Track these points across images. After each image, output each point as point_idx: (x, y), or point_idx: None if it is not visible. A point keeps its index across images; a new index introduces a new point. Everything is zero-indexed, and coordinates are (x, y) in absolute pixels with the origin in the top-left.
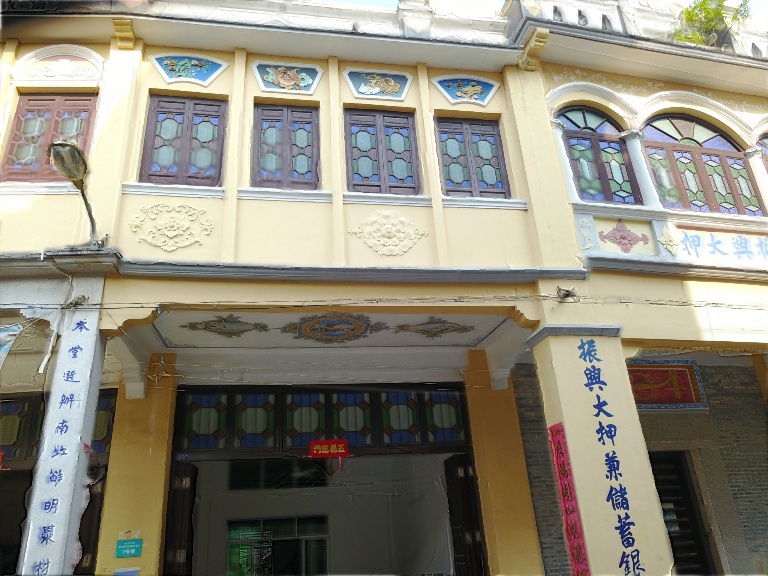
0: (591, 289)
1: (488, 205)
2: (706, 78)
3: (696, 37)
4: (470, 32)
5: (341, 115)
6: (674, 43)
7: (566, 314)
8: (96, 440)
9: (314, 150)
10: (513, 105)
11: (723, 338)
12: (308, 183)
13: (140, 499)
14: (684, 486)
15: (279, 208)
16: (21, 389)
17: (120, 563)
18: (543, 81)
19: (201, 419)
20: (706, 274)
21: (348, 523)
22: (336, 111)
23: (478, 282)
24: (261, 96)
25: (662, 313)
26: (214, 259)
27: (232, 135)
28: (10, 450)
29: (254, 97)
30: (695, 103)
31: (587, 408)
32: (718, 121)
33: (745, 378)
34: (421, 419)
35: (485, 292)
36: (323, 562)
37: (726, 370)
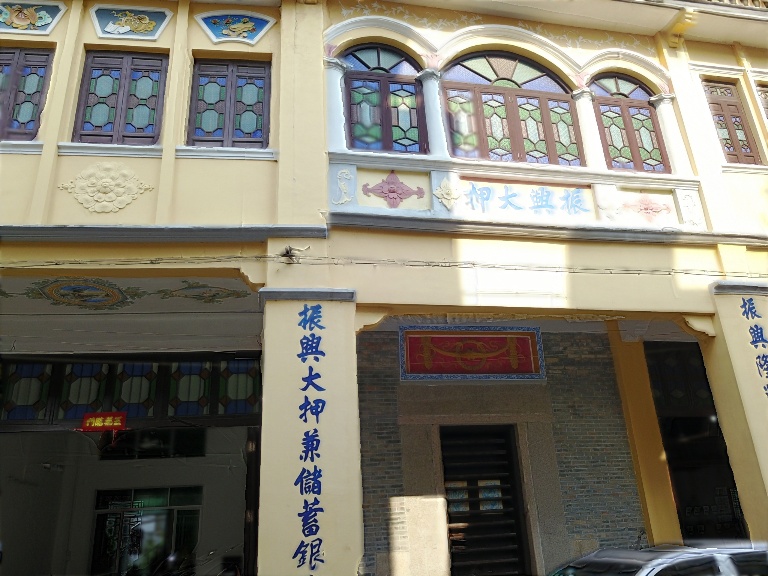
0: (333, 248)
1: (229, 155)
2: (531, 9)
3: None
4: None
5: (81, 57)
6: None
7: (293, 276)
8: None
9: (42, 97)
10: (281, 43)
11: (490, 303)
12: (28, 133)
13: None
14: (510, 462)
15: None
16: None
17: None
18: (324, 15)
19: None
20: (480, 231)
21: (223, 493)
22: (69, 53)
23: (193, 241)
24: None
25: (417, 275)
26: None
27: None
28: None
29: None
30: (516, 38)
31: (294, 381)
32: (543, 59)
33: (596, 346)
34: (213, 390)
35: (202, 252)
36: (195, 532)
37: (574, 337)
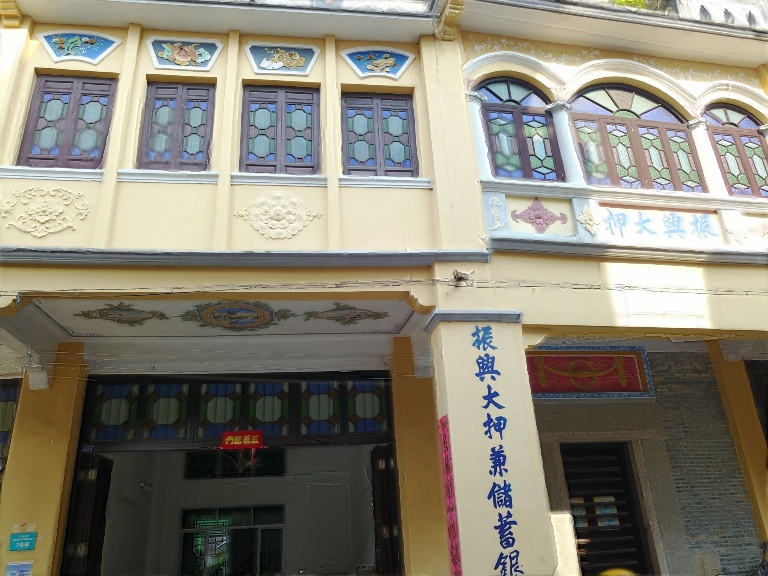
0: (494, 272)
1: (388, 184)
2: (647, 44)
3: (637, 0)
4: (387, 1)
5: (240, 92)
6: (605, 7)
7: (462, 299)
8: (3, 431)
9: (207, 129)
10: (425, 77)
11: (641, 323)
12: (198, 164)
13: (38, 491)
14: (625, 479)
15: (162, 190)
16: None
17: (13, 556)
18: (461, 51)
19: (111, 409)
20: (626, 255)
21: (305, 512)
22: (232, 88)
23: (367, 266)
24: (155, 74)
25: (573, 297)
26: (85, 245)
27: (117, 115)
28: None
29: (146, 75)
30: (634, 72)
31: (475, 399)
32: (659, 91)
33: (699, 365)
34: (342, 409)
35: (375, 276)
36: (279, 551)
37: (678, 357)
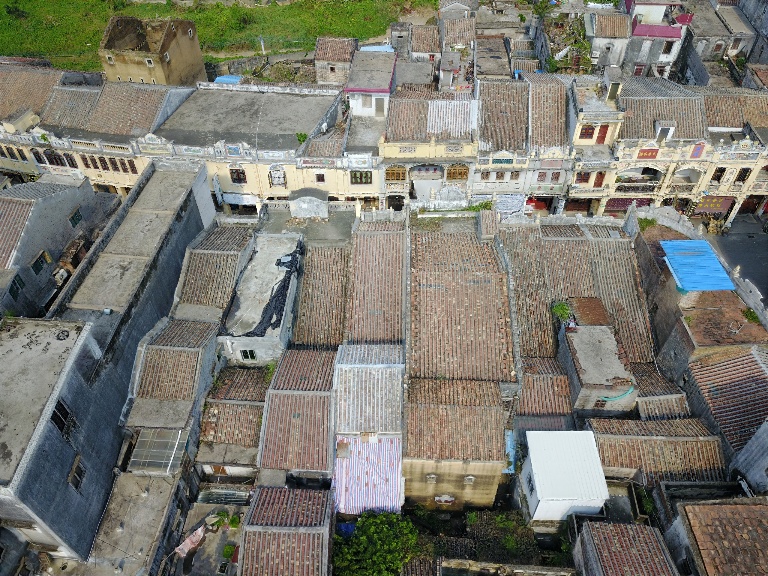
0: None
1: None
2: None
3: None
4: None
5: (5, 147)
6: None
7: None
8: None
9: None
10: None
11: None
12: None
13: None
14: None
15: None
16: None
17: None
18: None
19: None
20: None
21: None
22: None
23: None
24: None
25: None
26: None
27: None
28: None
29: None
30: None
31: None
32: None
33: None
34: None
35: None
36: None
37: None
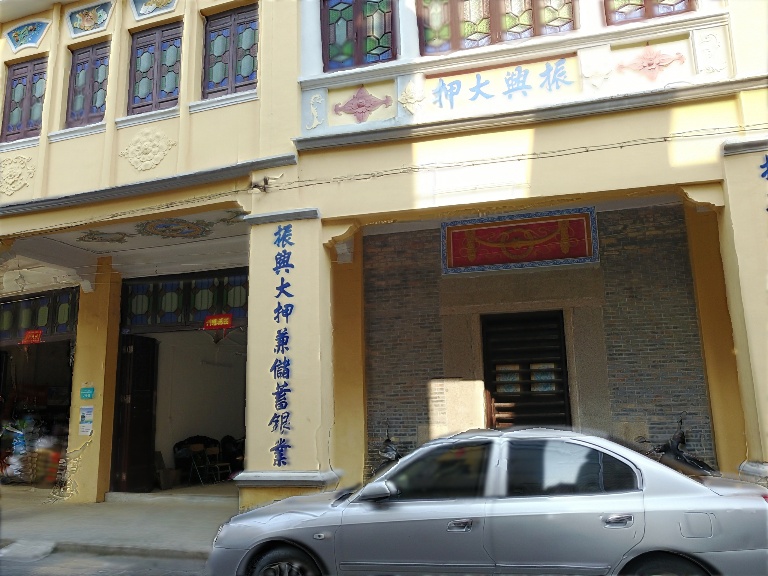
0: (304, 172)
1: (226, 103)
2: None
3: None
4: None
5: (129, 42)
6: None
7: (270, 202)
8: None
9: None
10: None
11: (447, 202)
12: (102, 115)
13: (93, 362)
14: (560, 346)
15: (76, 144)
16: (44, 289)
17: (83, 403)
18: None
19: (138, 303)
20: (438, 131)
21: None
22: (117, 41)
23: (199, 184)
24: (74, 43)
25: (377, 185)
26: None
27: (47, 88)
28: (45, 329)
29: (68, 46)
30: None
31: (270, 290)
32: None
33: (666, 220)
34: None
35: (207, 192)
36: None
37: (638, 213)
